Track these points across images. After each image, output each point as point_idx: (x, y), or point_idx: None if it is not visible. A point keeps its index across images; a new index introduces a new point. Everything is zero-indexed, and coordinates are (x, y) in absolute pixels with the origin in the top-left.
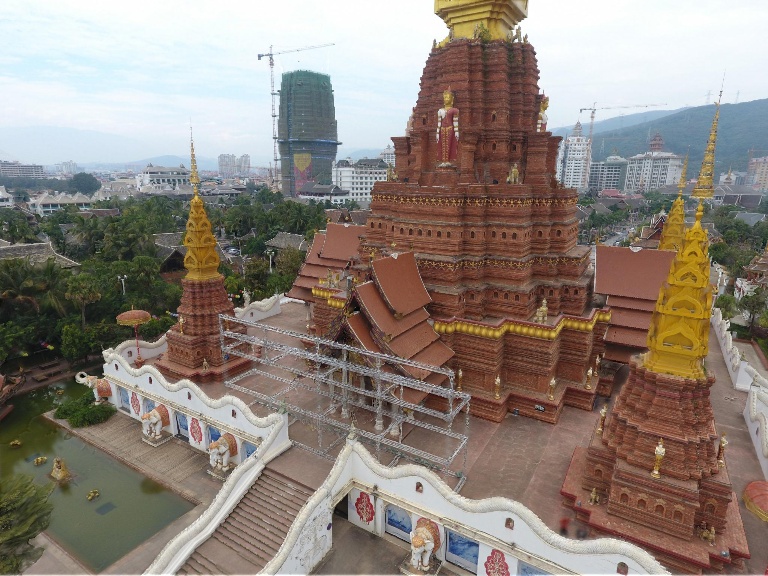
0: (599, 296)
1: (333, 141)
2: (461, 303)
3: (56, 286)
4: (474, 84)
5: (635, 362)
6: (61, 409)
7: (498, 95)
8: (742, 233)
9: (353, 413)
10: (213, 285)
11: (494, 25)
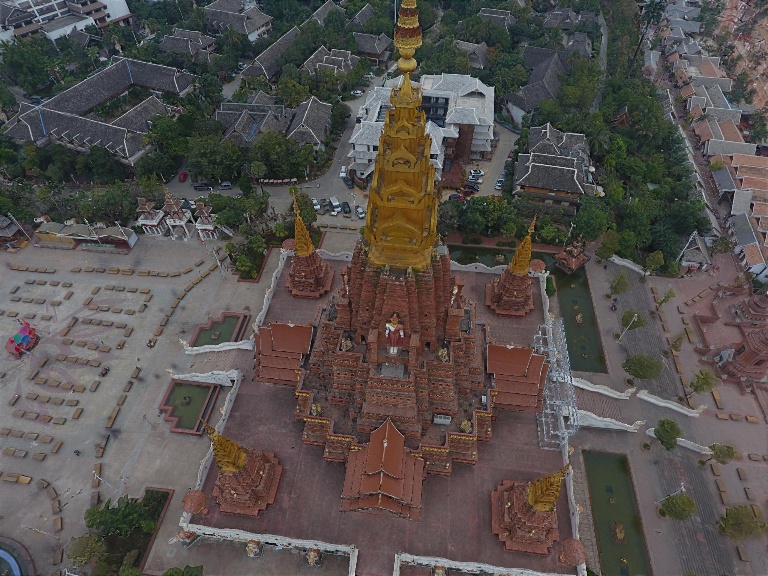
0: None
1: None
2: None
3: None
4: None
5: None
6: None
7: None
8: None
9: None
10: None
11: None
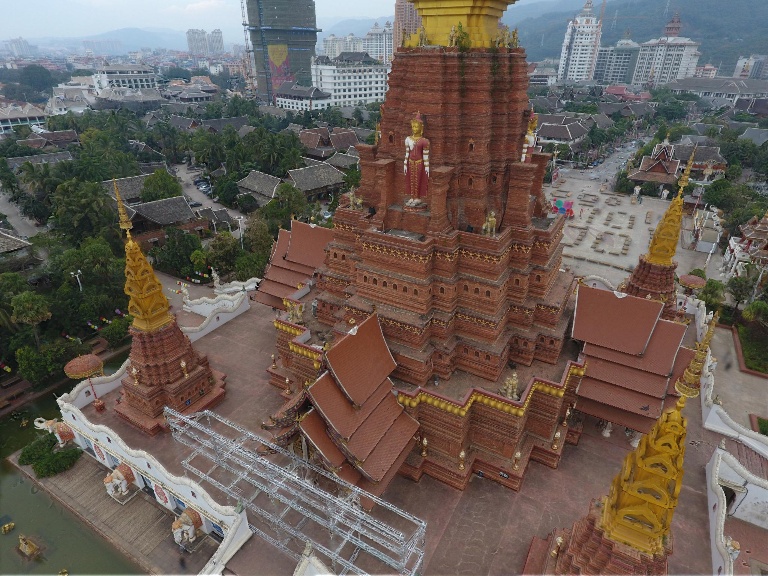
0: (576, 340)
1: (311, 28)
2: (428, 366)
3: (2, 299)
4: (448, 106)
5: (594, 517)
6: (25, 454)
7: (477, 121)
8: (748, 156)
9: (316, 481)
10: (164, 333)
11: (476, 22)
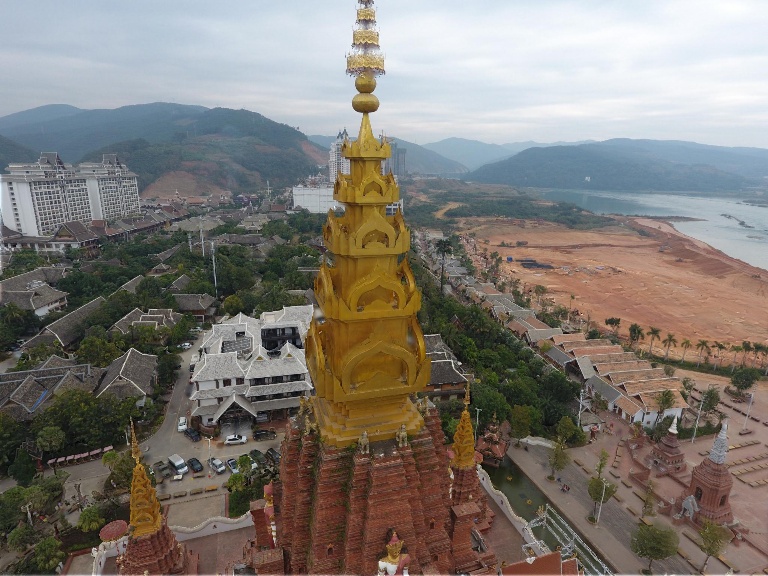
0: None
1: None
2: None
3: None
4: None
5: (472, 467)
6: None
7: None
8: None
9: None
10: None
11: None
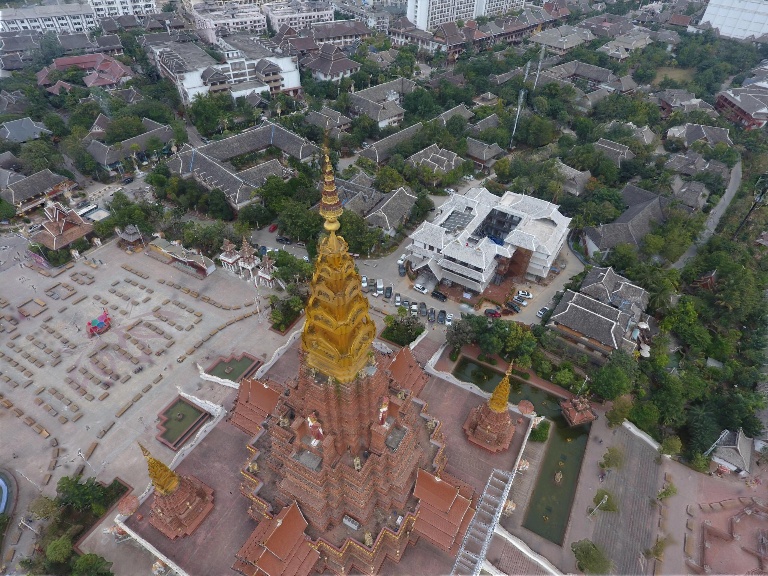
0: None
1: None
2: None
3: None
4: None
5: (498, 412)
6: None
7: None
8: None
9: None
10: None
11: None
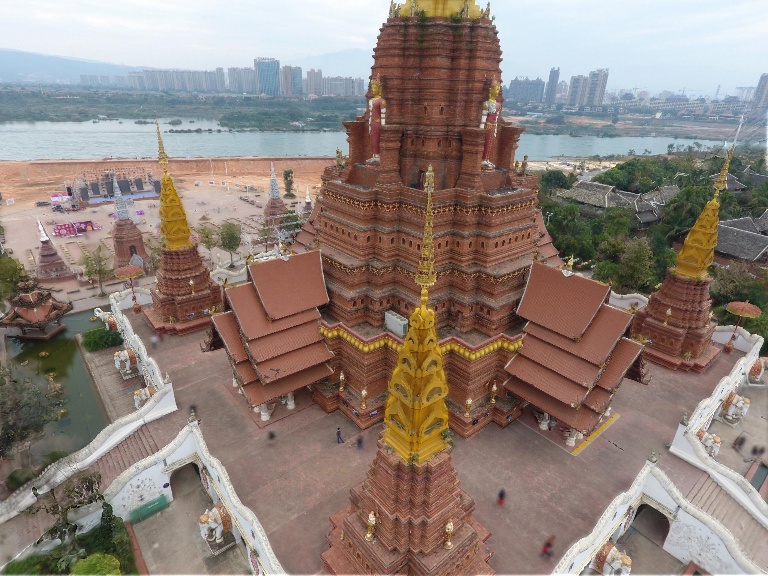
0: None
1: None
2: None
3: None
4: None
5: None
6: None
7: None
8: None
9: None
10: None
11: None
